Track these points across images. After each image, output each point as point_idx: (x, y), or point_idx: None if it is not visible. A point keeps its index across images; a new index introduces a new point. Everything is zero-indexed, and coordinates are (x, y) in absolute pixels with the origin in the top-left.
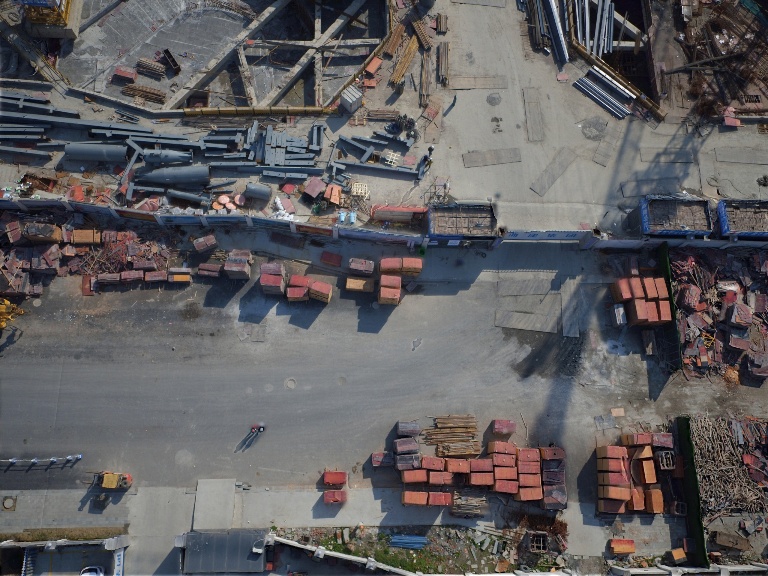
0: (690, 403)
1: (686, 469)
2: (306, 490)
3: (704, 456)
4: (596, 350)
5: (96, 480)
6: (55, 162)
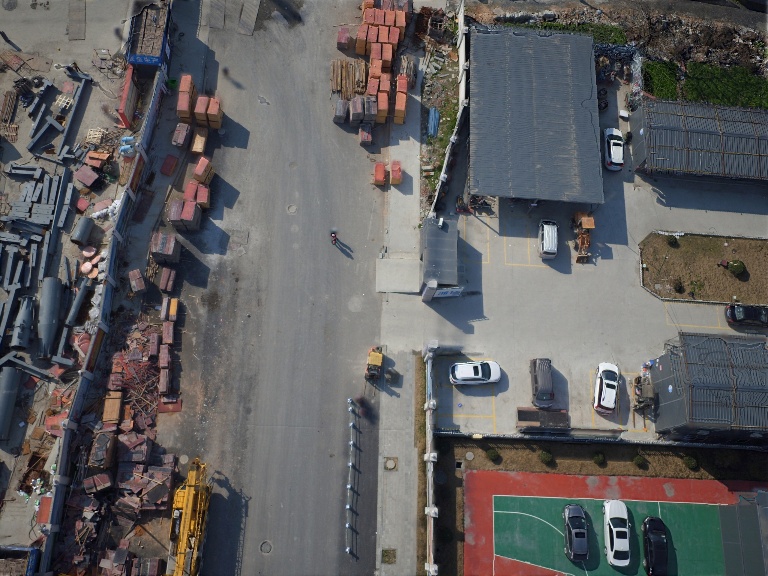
0: None
1: None
2: (389, 199)
3: None
4: None
5: (374, 372)
6: (7, 458)
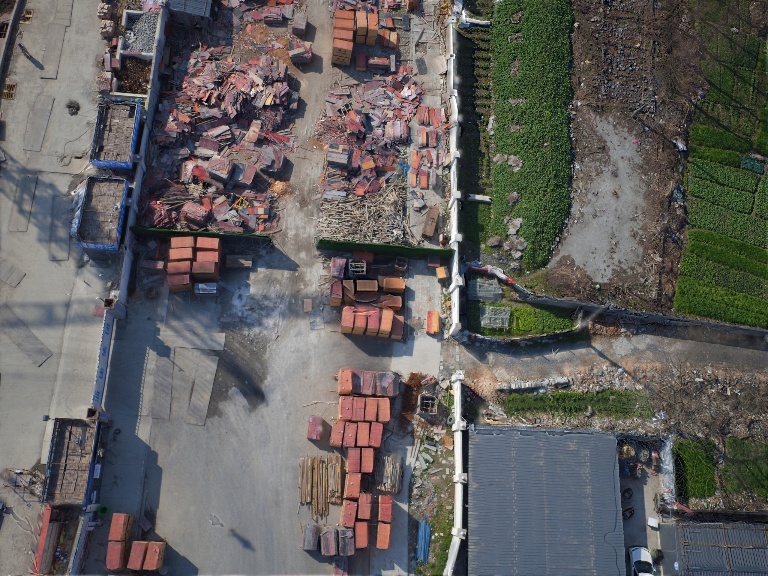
0: (304, 233)
1: (366, 250)
2: None
3: (355, 232)
4: (242, 317)
5: None
6: None
